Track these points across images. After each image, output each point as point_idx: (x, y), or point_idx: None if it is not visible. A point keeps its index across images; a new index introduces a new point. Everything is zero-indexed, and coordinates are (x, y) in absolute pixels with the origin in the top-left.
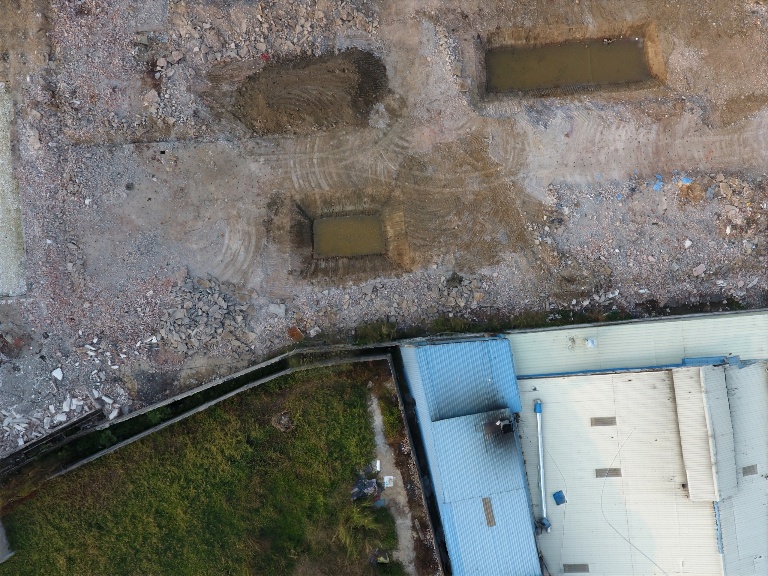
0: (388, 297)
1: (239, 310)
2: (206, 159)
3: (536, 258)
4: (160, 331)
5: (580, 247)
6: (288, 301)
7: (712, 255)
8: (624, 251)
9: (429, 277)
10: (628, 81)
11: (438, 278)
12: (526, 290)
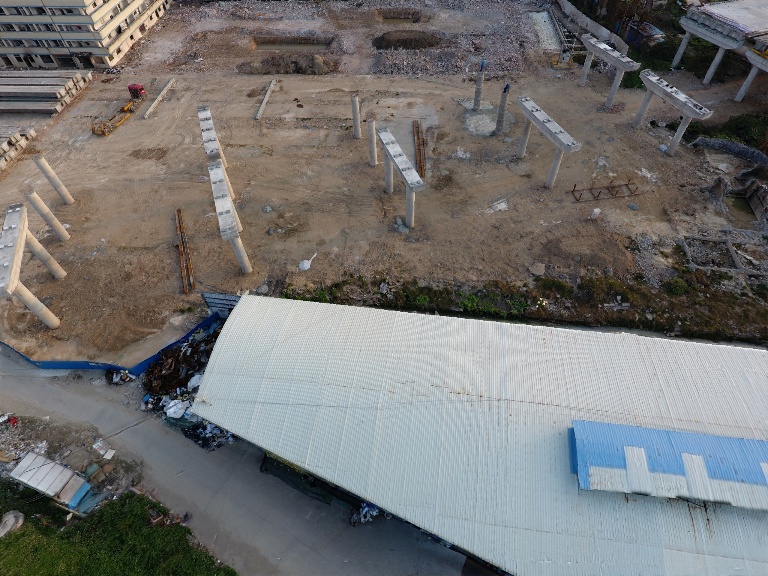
0: (386, 1)
1: (443, 3)
2: (454, 30)
3: (326, 7)
4: (474, 1)
5: (309, 8)
6: (424, 5)
7: (260, 5)
8: (292, 7)
9: (369, 6)
10: (267, 44)
11: (365, 6)
12: (333, 2)
